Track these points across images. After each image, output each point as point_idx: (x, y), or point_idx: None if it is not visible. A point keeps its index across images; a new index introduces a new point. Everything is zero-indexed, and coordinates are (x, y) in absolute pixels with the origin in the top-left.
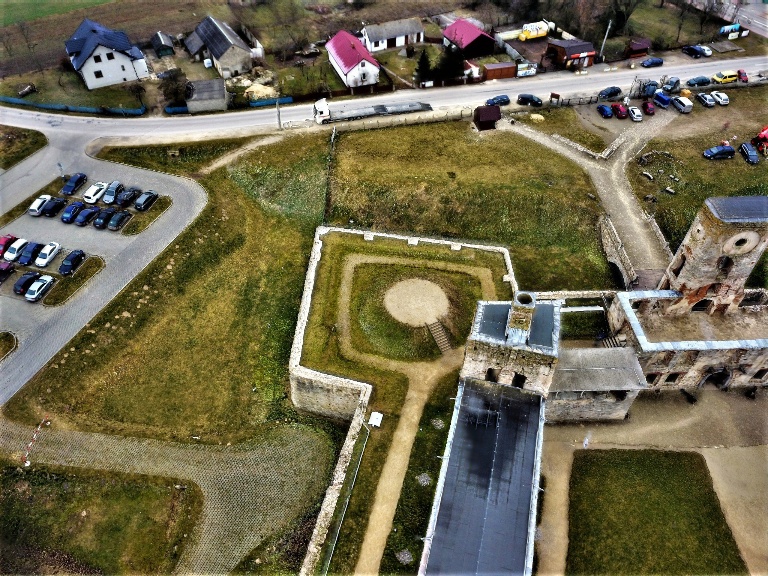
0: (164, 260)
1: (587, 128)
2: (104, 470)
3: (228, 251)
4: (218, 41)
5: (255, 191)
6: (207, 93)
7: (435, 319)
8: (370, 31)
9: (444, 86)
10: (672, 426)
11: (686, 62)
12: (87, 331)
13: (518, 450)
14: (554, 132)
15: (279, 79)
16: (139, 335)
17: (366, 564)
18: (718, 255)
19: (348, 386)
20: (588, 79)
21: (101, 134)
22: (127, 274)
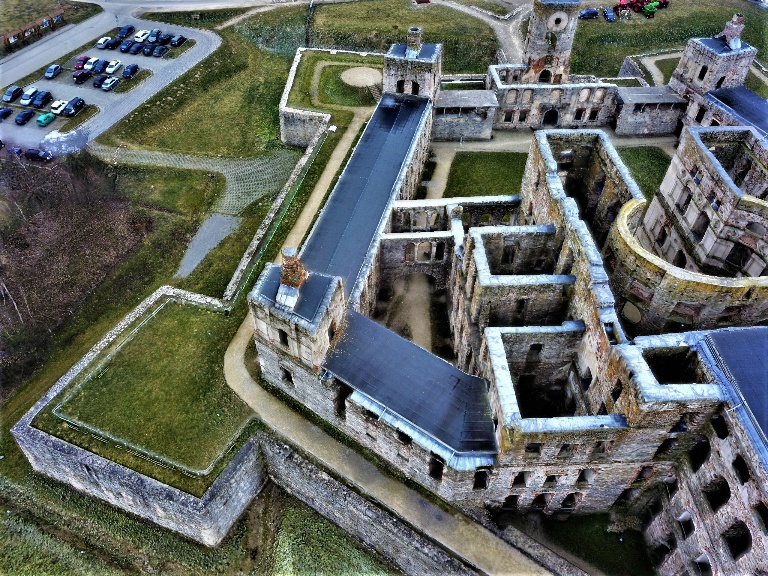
0: (193, 72)
1: (497, 3)
2: (163, 166)
3: (237, 71)
4: None
5: (255, 40)
6: None
7: (373, 84)
8: None
9: None
10: (520, 142)
11: None
12: (145, 105)
13: (411, 117)
14: (472, 5)
15: None
16: (179, 110)
17: (323, 181)
18: (545, 31)
19: (316, 115)
20: None
21: (142, 6)
22: (169, 78)
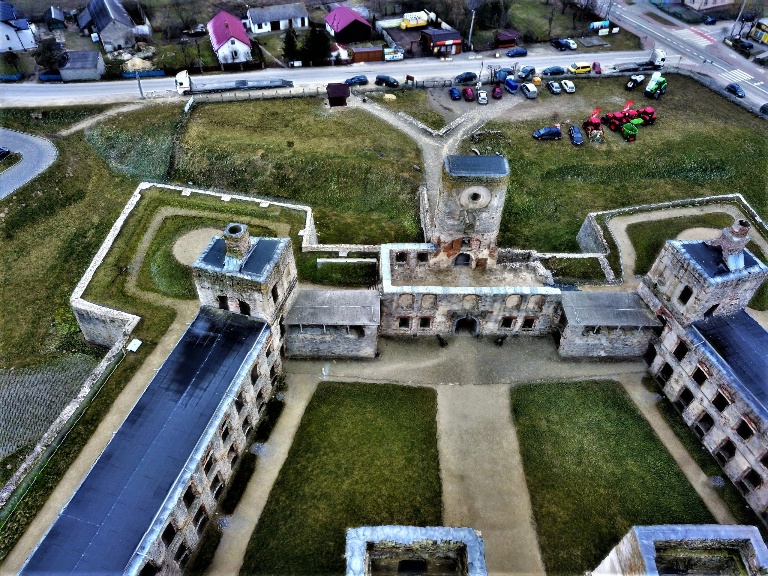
0: None
1: (433, 108)
2: None
3: (65, 204)
4: (102, 16)
5: (107, 153)
6: (80, 63)
7: None
8: (253, 13)
9: (312, 66)
10: (417, 365)
11: (550, 54)
12: None
13: (224, 365)
14: (401, 110)
15: (160, 54)
16: None
17: (81, 463)
18: (458, 208)
19: (118, 317)
20: (451, 65)
21: None
22: None
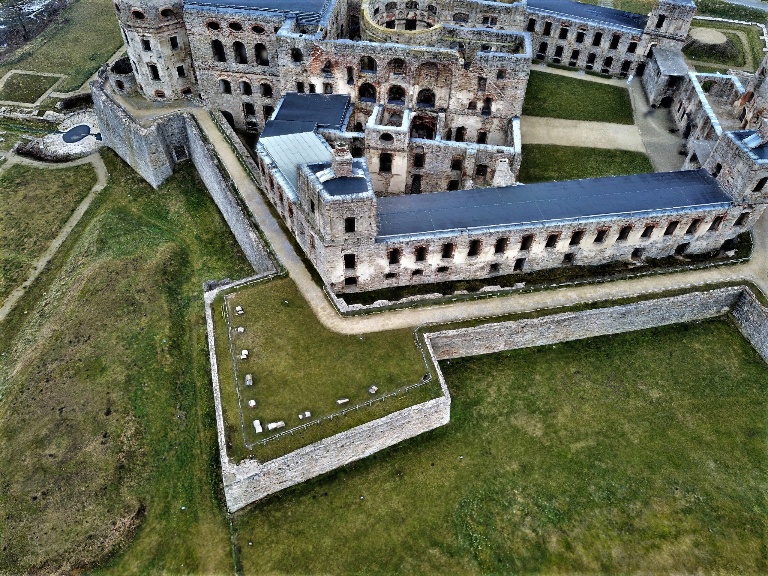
0: (722, 3)
1: None
2: (597, 1)
3: None
4: None
5: None
6: None
7: (696, 39)
8: None
9: None
10: (651, 120)
11: None
12: None
13: None
14: None
15: None
16: None
17: None
18: (764, 64)
19: None
20: None
21: None
22: None
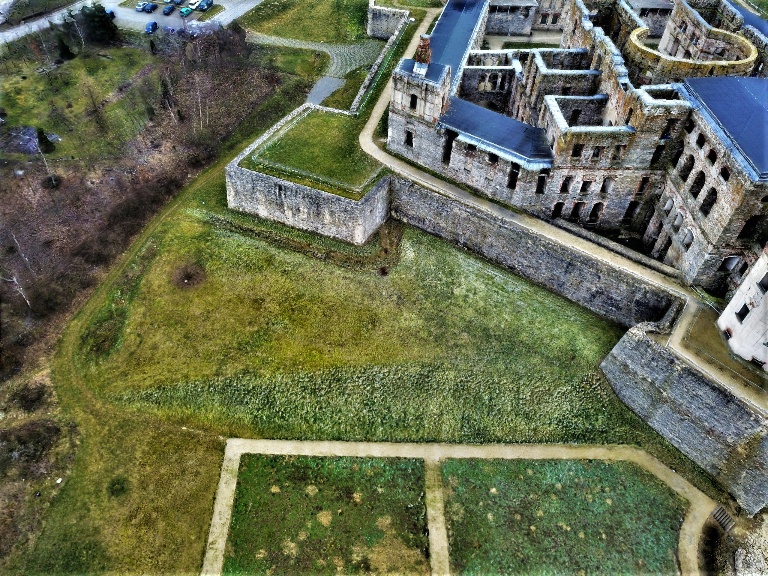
0: None
1: None
2: (281, 46)
3: None
4: None
5: None
6: None
7: None
8: None
9: None
10: (553, 38)
11: None
12: (259, 6)
13: (476, 5)
14: None
15: None
16: (284, 12)
17: (410, 49)
18: None
19: (398, 11)
20: None
21: None
22: None
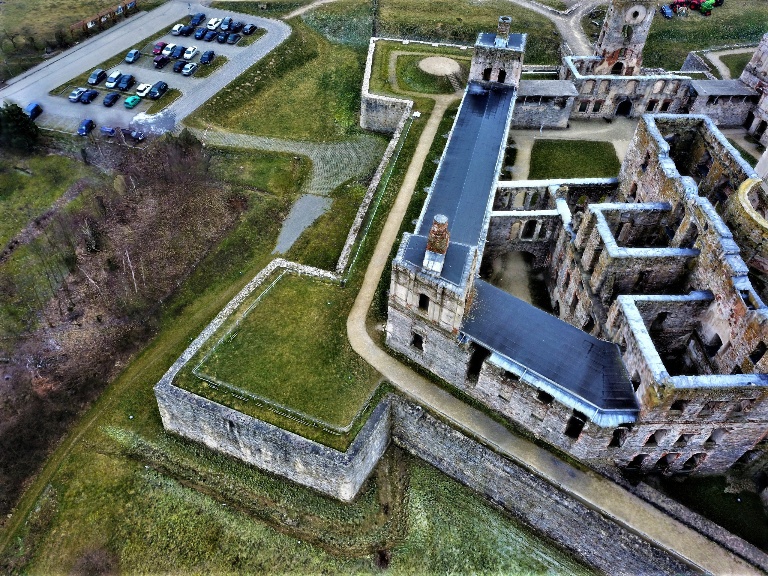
0: (268, 59)
1: None
2: (250, 149)
3: (308, 59)
4: None
5: (322, 30)
6: None
7: (451, 73)
8: None
9: None
10: (595, 131)
11: None
12: (225, 90)
13: (501, 103)
14: None
15: None
16: (257, 96)
17: (415, 163)
18: (623, 24)
19: (399, 101)
20: None
21: None
22: (245, 65)
